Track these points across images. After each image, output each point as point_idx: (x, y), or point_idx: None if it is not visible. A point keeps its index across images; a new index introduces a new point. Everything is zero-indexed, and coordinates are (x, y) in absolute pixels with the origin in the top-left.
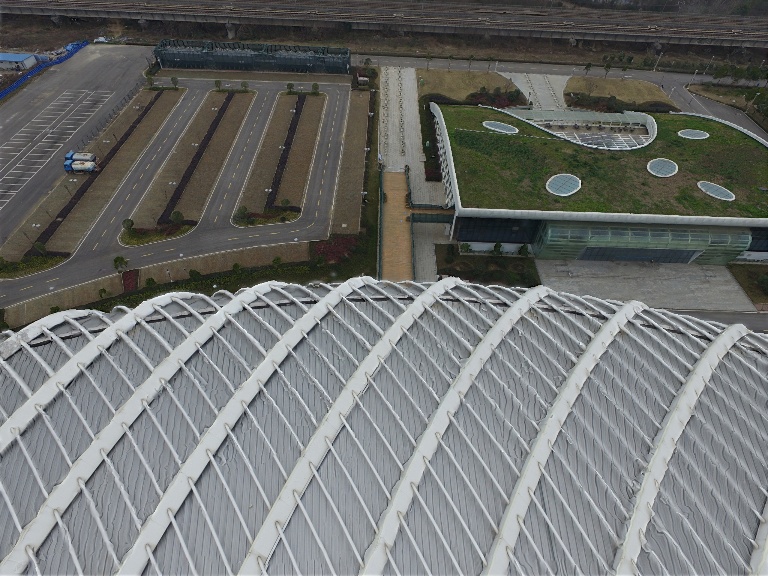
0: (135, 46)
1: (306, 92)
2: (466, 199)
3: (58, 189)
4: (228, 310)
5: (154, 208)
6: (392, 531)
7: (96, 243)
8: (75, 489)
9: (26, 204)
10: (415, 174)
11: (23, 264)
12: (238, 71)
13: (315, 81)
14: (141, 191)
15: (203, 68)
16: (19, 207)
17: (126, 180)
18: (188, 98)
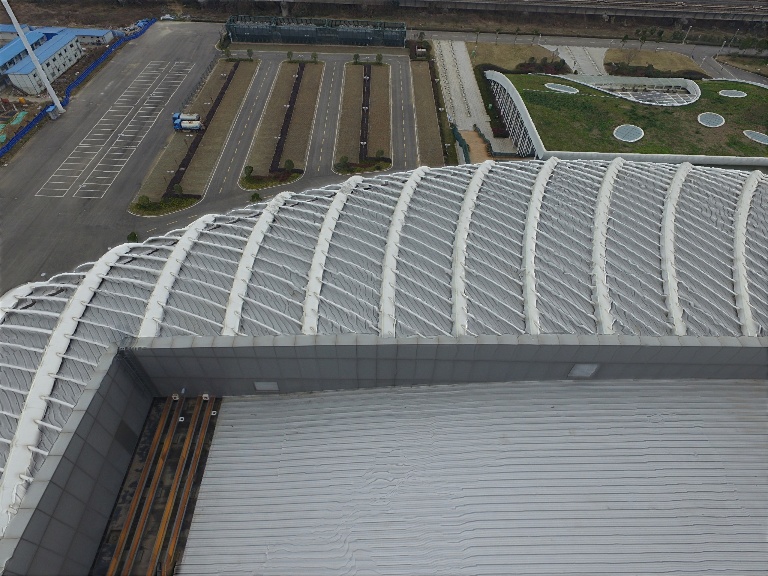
0: (200, 23)
1: (370, 62)
2: (547, 144)
3: (172, 145)
4: (482, 170)
5: (262, 160)
6: (672, 257)
7: (220, 188)
8: (465, 243)
9: (148, 157)
10: (483, 132)
11: (164, 204)
12: (303, 44)
13: (375, 53)
14: (246, 146)
15: (270, 42)
16: (143, 159)
17: (230, 137)
18: (264, 68)
